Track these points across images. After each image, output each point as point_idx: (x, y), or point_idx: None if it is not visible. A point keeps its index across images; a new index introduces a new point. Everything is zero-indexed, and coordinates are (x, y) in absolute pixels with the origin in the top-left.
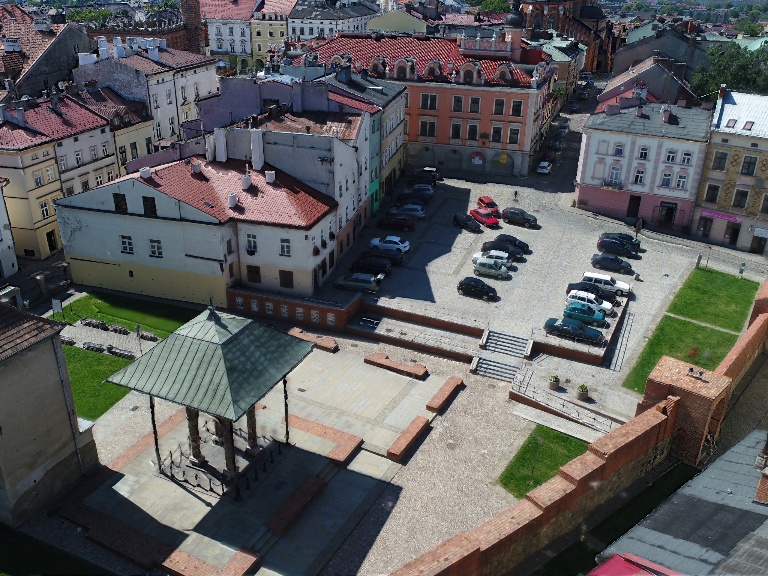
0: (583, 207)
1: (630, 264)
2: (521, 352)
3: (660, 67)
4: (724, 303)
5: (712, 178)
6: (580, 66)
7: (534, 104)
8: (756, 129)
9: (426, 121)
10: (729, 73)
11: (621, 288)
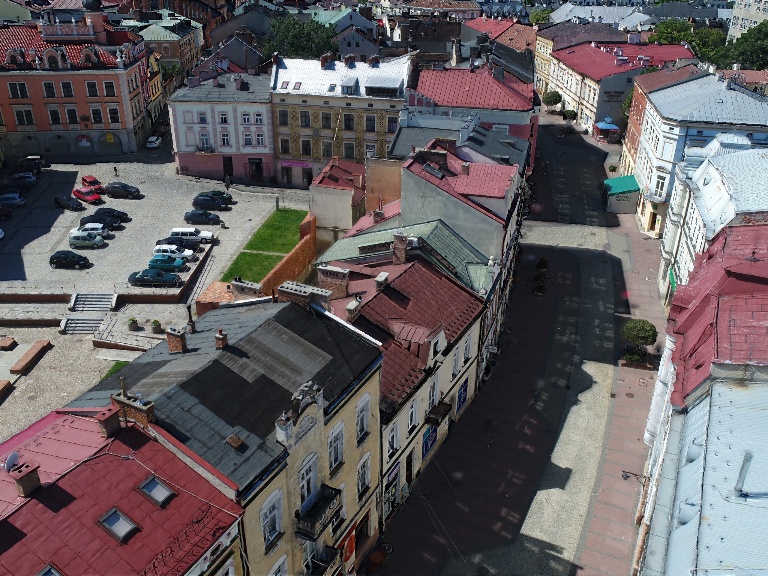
0: (186, 173)
1: (220, 216)
2: (107, 306)
3: (238, 41)
4: (292, 234)
5: (282, 133)
6: (197, 43)
7: (126, 83)
8: (303, 88)
9: (21, 110)
10: (287, 42)
11: (204, 236)
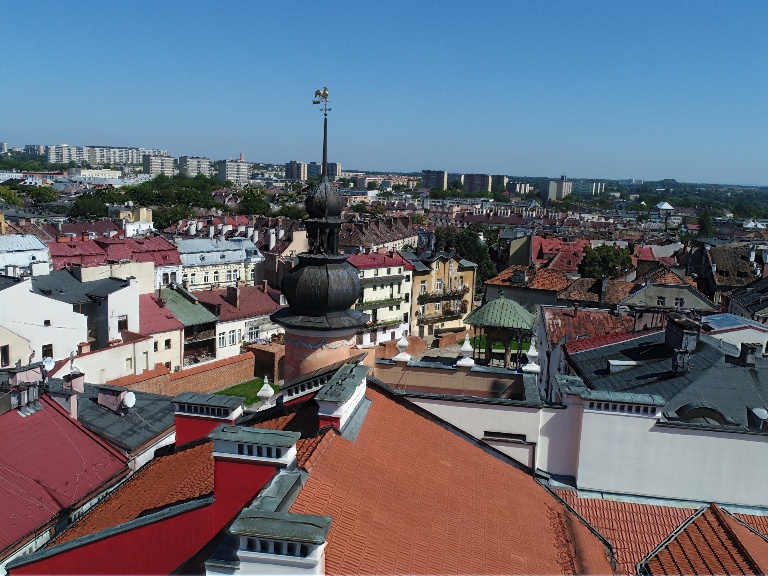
0: None
1: None
2: None
3: None
4: None
5: None
6: None
7: None
8: None
9: None
10: None
11: None
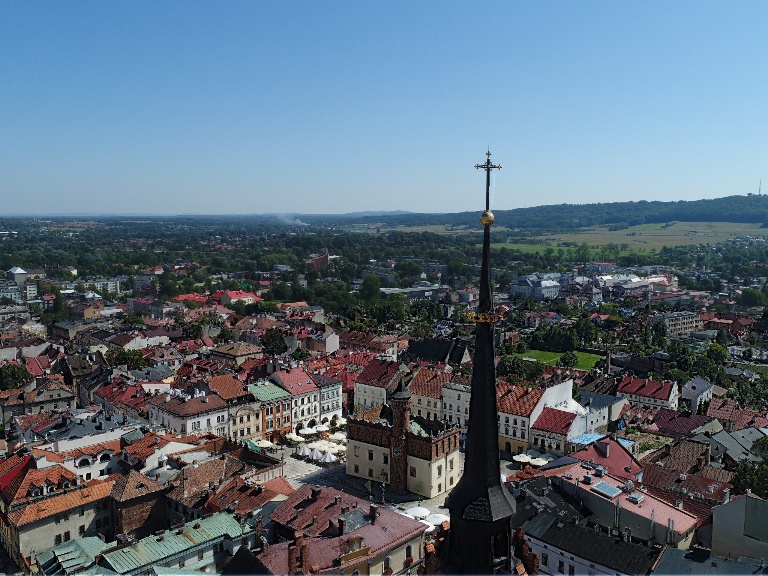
0: None
1: None
2: None
3: None
4: None
5: None
6: None
7: None
8: None
9: None
10: None
11: None
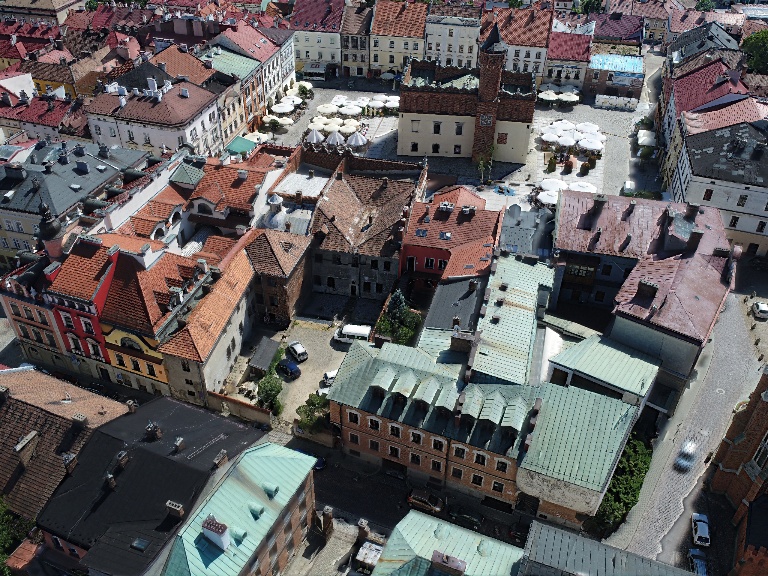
0: None
1: None
2: None
3: None
4: None
5: None
6: None
7: None
8: None
9: None
10: None
11: None
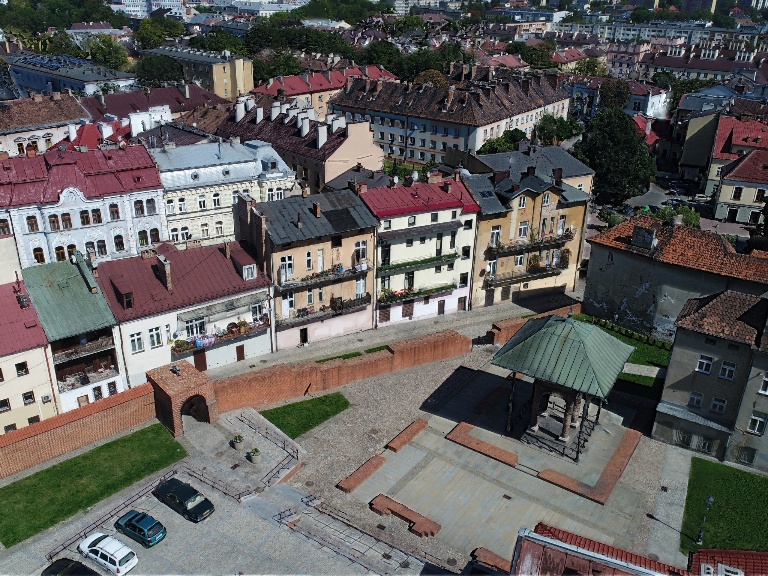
0: None
1: None
2: None
3: None
4: None
5: None
6: None
7: None
8: None
9: None
10: None
11: None
